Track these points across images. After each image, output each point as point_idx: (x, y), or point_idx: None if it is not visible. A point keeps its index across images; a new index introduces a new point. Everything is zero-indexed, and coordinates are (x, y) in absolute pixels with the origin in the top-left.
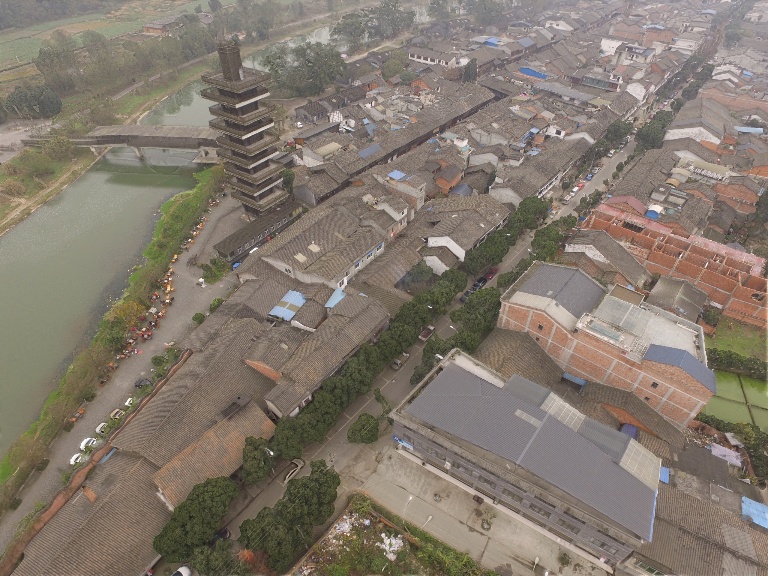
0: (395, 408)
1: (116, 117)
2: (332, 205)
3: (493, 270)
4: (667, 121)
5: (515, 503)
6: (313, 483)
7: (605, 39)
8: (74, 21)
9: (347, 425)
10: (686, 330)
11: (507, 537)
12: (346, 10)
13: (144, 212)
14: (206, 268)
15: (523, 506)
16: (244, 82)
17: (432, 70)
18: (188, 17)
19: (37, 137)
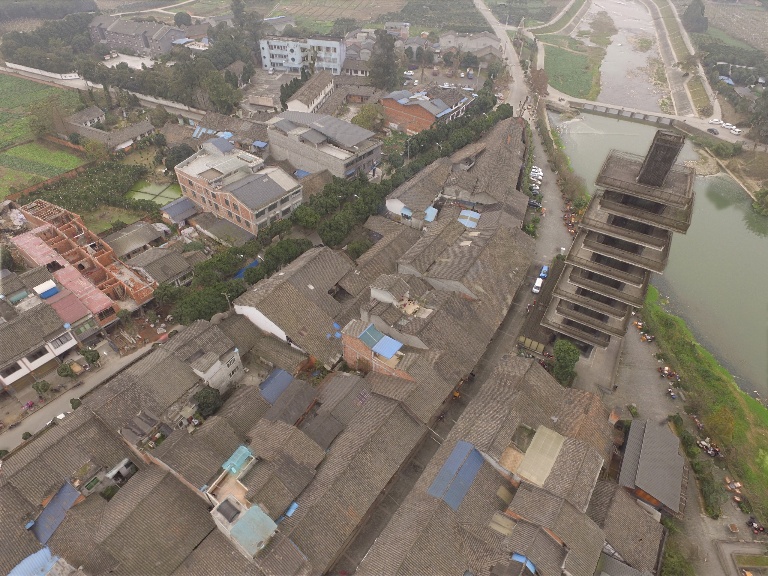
0: None
1: None
2: None
3: None
4: None
5: None
6: (415, 136)
7: None
8: None
9: None
10: None
11: None
12: None
13: None
14: None
15: None
16: (610, 153)
17: None
18: None
19: None
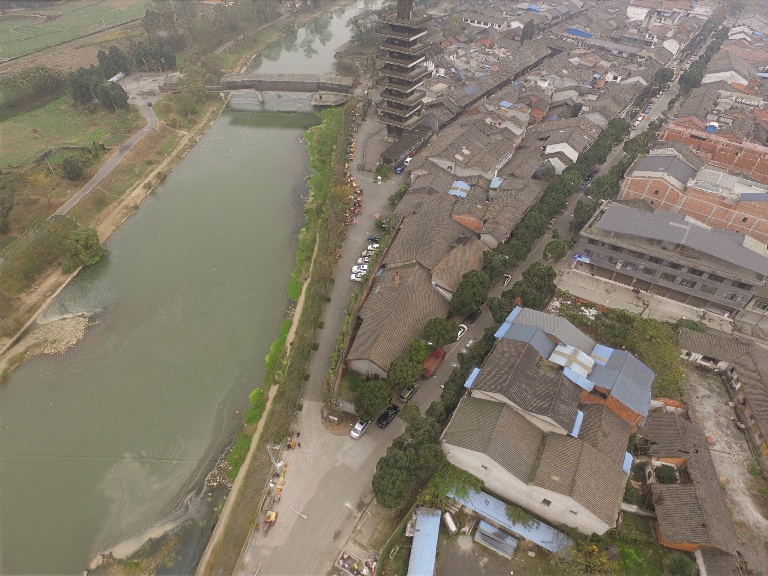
0: (582, 230)
1: (222, 71)
2: (462, 126)
3: (595, 171)
4: (703, 68)
5: (669, 283)
6: (544, 269)
7: (631, 7)
8: None
9: (530, 258)
10: (759, 190)
11: (661, 308)
12: None
13: (291, 140)
14: (380, 170)
15: (675, 284)
16: (420, 20)
17: (488, 32)
18: None
19: (170, 84)
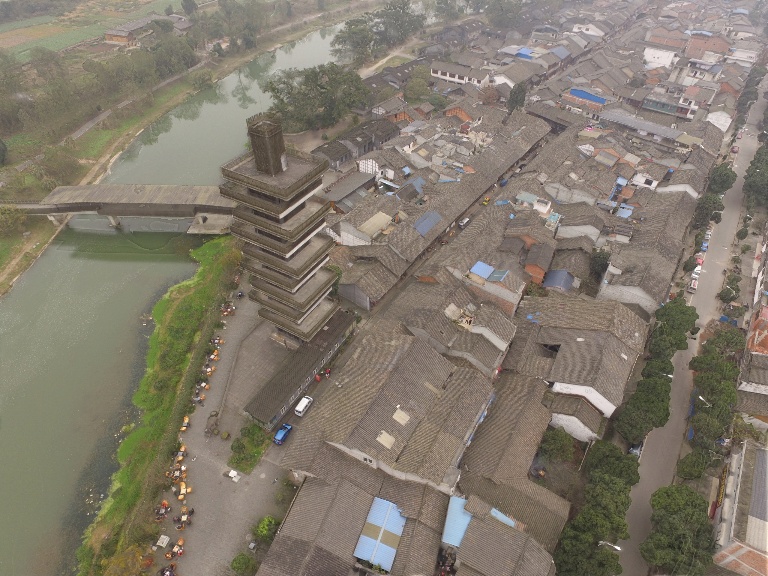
0: None
1: (79, 163)
2: (404, 324)
3: None
4: None
5: None
6: None
7: (649, 48)
8: (19, 25)
9: None
10: None
11: None
12: (338, 9)
13: (129, 321)
14: (237, 449)
15: None
16: (294, 182)
17: (464, 91)
18: (160, 23)
19: None
